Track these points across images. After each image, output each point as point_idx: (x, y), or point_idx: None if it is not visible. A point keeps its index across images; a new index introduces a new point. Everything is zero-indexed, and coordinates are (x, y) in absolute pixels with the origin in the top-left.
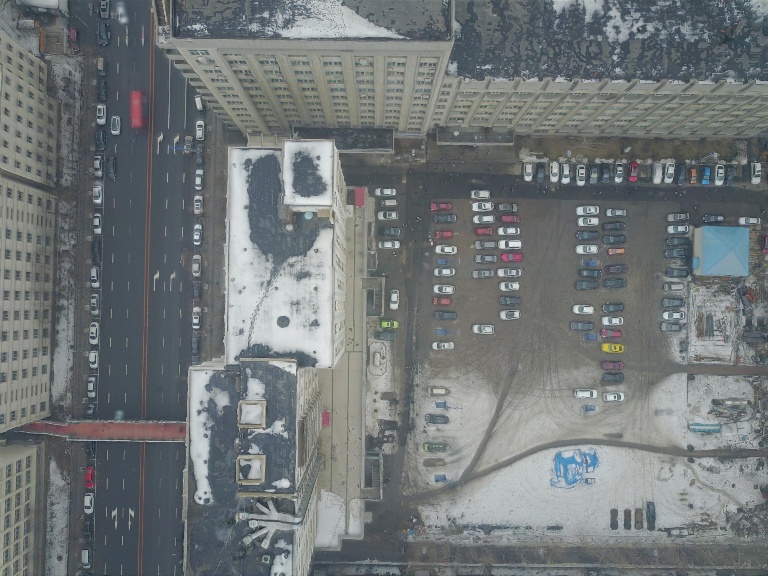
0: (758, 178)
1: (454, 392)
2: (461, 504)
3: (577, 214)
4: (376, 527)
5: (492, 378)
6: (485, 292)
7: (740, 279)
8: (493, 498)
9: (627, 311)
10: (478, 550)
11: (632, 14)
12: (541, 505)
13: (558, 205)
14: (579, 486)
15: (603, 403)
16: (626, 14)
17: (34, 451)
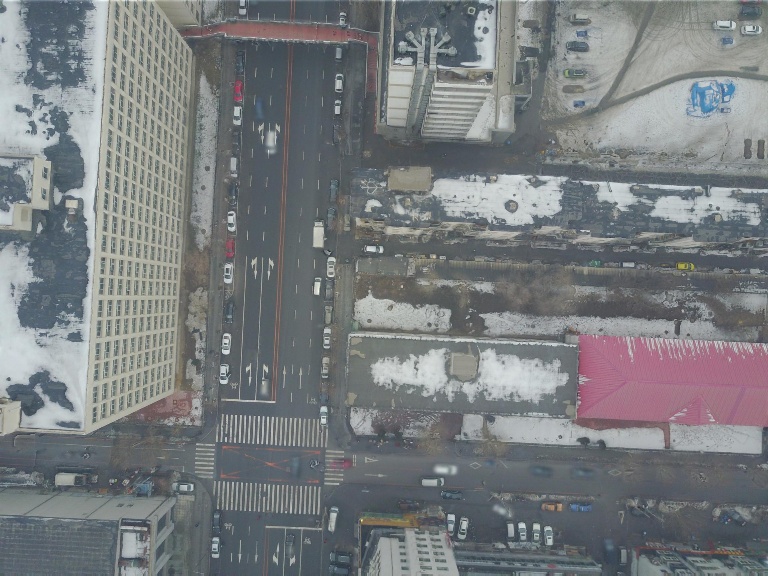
0: None
1: (595, 22)
2: (598, 130)
3: None
4: (515, 149)
5: (632, 10)
6: None
7: None
8: (630, 125)
9: None
10: (614, 175)
11: None
12: (677, 133)
13: None
14: (714, 116)
15: (740, 37)
16: None
17: (191, 51)
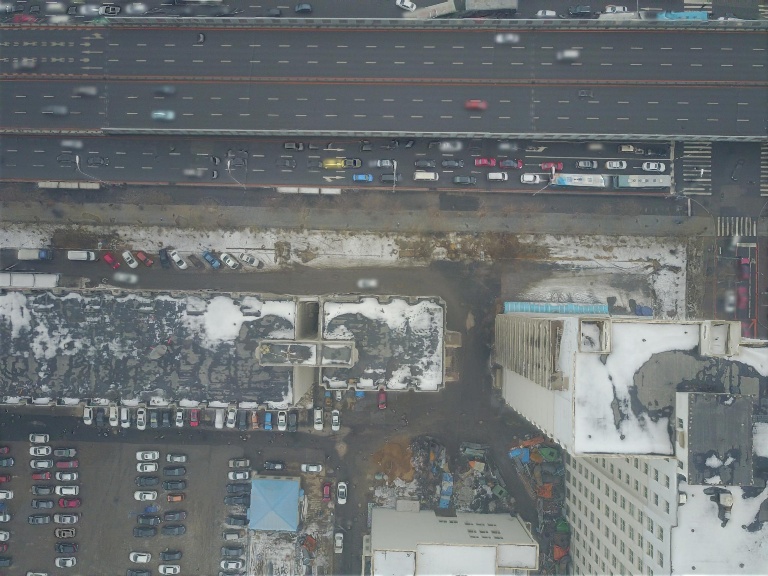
0: (320, 425)
1: None
2: None
3: (137, 459)
4: None
5: None
6: (43, 537)
7: (302, 527)
8: None
9: (186, 558)
10: None
11: (60, 330)
12: None
13: (119, 448)
14: None
15: None
16: (54, 330)
17: None
